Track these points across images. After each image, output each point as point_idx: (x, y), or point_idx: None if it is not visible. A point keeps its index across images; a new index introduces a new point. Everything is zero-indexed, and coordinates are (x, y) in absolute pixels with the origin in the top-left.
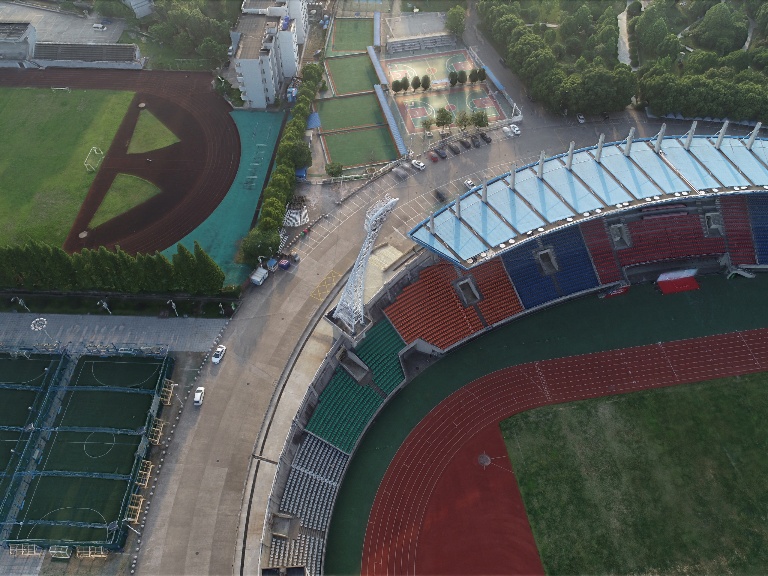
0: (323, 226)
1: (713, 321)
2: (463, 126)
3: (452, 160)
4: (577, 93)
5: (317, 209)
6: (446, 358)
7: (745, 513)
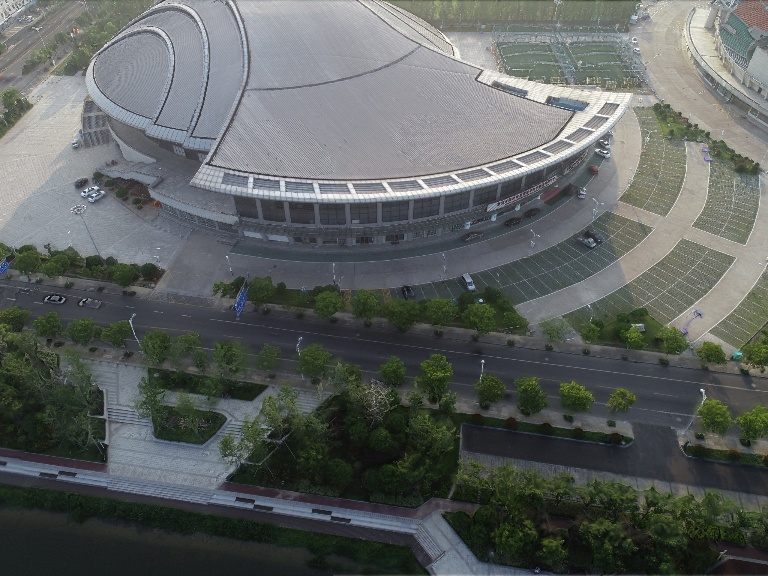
0: (653, 8)
1: None
2: None
3: None
4: None
5: None
6: (767, 42)
7: None
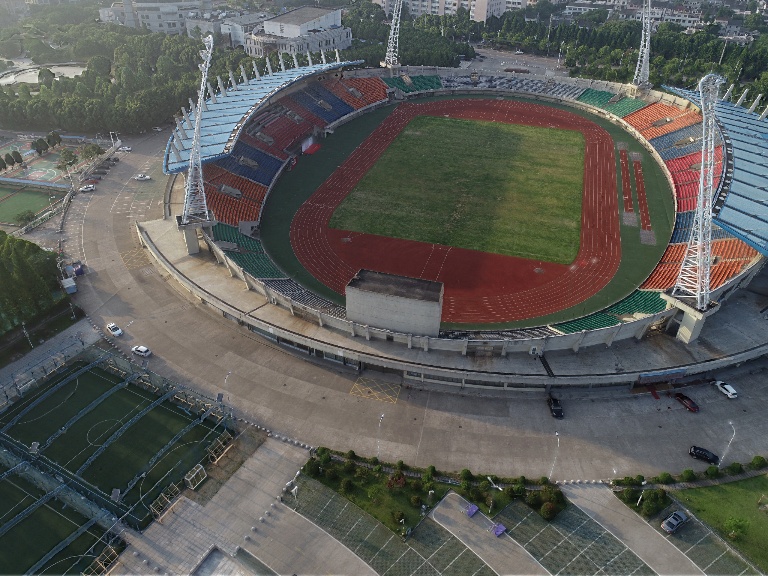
0: (70, 245)
1: (344, 150)
2: (90, 157)
3: (107, 177)
4: (145, 108)
5: (47, 243)
6: (262, 231)
7: (447, 181)
